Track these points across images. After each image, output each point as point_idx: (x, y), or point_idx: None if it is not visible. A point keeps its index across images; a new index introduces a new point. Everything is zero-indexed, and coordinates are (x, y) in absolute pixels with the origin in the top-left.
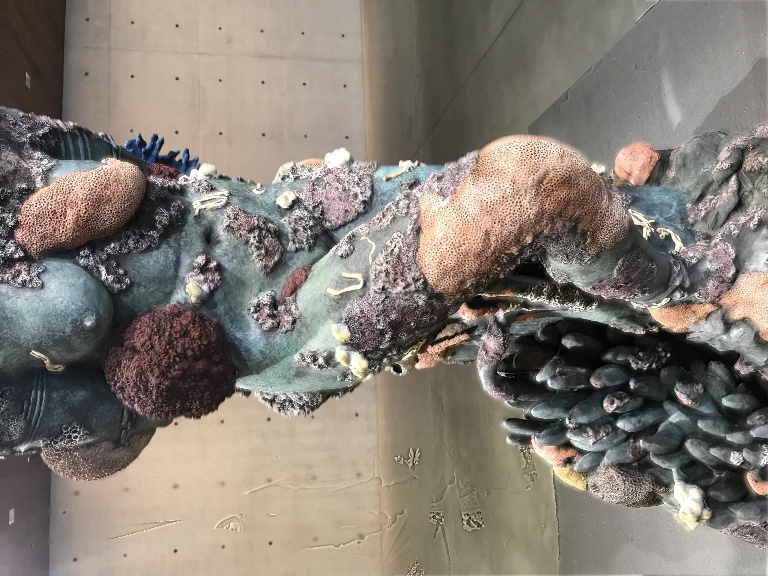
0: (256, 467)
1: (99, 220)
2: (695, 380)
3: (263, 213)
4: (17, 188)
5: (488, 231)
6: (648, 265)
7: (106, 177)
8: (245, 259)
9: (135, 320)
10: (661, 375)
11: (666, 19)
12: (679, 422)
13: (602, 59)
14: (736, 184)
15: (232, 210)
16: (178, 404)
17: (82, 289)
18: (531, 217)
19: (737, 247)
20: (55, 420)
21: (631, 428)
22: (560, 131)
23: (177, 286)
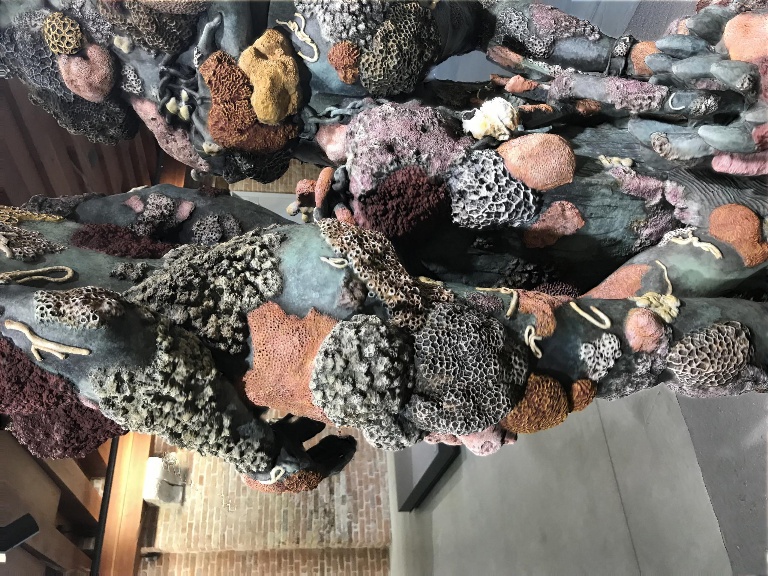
0: None
1: None
2: None
3: None
4: None
5: None
6: None
7: None
8: None
9: None
10: None
11: None
12: None
13: None
14: None
15: None
16: None
17: None
18: None
19: None
20: None
21: None
22: None
23: None
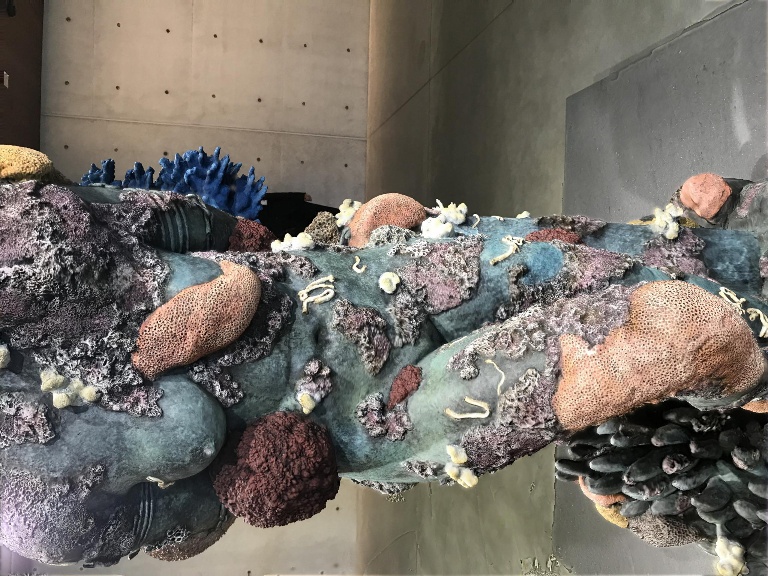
0: None
1: (218, 338)
2: (753, 446)
3: (369, 302)
4: (135, 310)
5: (635, 388)
6: (762, 388)
7: (227, 293)
8: (355, 361)
9: (247, 433)
10: (720, 438)
11: (749, 25)
12: (730, 482)
13: (665, 48)
14: None
15: (341, 305)
16: (289, 519)
17: (201, 415)
18: (683, 379)
19: None
20: (161, 527)
21: (686, 488)
22: (605, 112)
23: (287, 393)
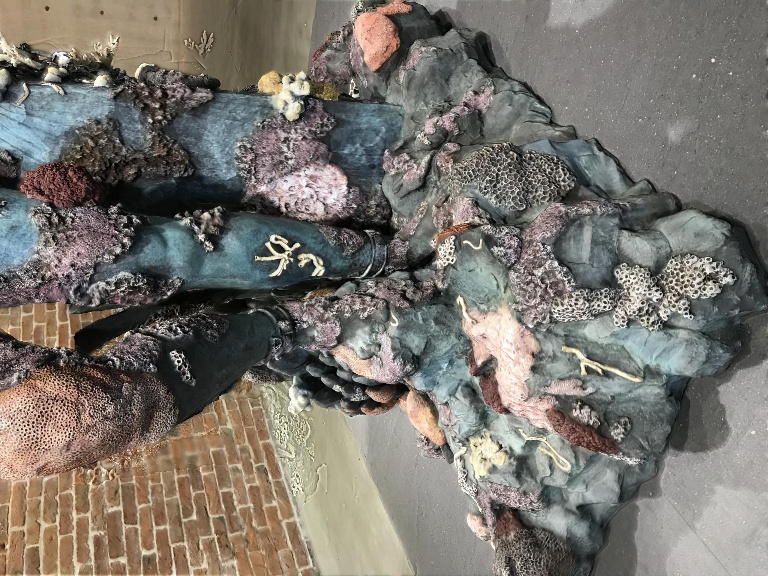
0: (21, 17)
1: None
2: None
3: None
4: None
5: None
6: None
7: None
8: None
9: None
10: None
11: None
12: None
13: None
14: (426, 168)
15: None
16: None
17: None
18: None
19: (345, 326)
20: None
21: None
22: None
23: None
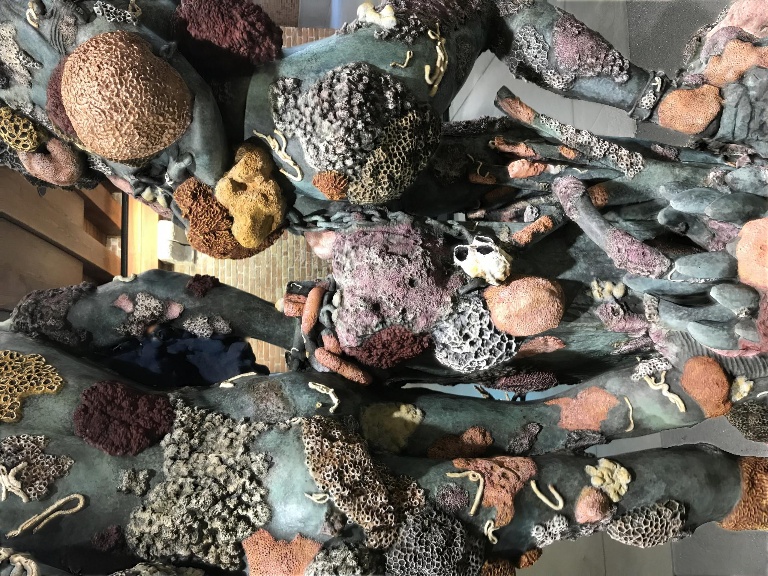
0: None
1: None
2: None
3: None
4: None
5: None
6: None
7: None
8: None
9: None
10: None
11: None
12: None
13: None
14: None
15: None
16: None
17: None
18: None
19: None
20: None
21: None
22: None
23: None
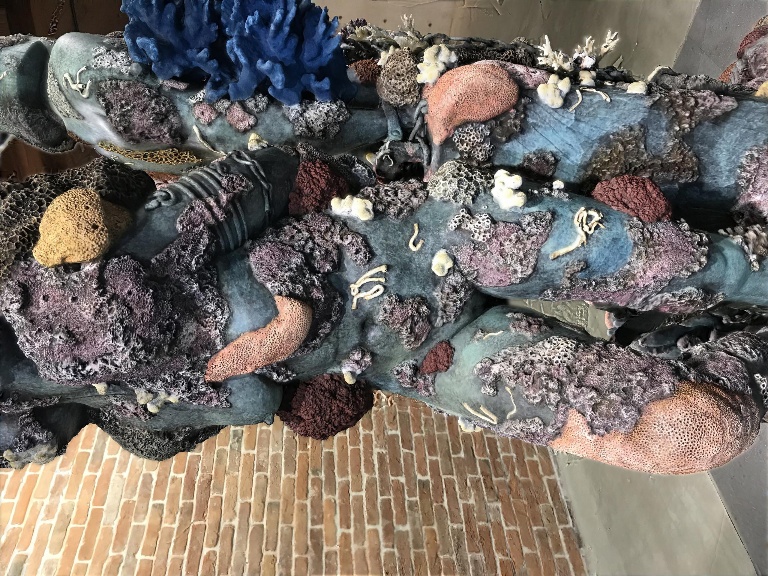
0: None
1: None
2: None
3: (417, 289)
4: (202, 357)
5: None
6: None
7: (279, 341)
8: (395, 344)
9: (299, 391)
10: None
11: None
12: None
13: None
14: None
15: (389, 303)
16: None
17: (262, 403)
18: None
19: None
20: None
21: None
22: None
23: (334, 365)
